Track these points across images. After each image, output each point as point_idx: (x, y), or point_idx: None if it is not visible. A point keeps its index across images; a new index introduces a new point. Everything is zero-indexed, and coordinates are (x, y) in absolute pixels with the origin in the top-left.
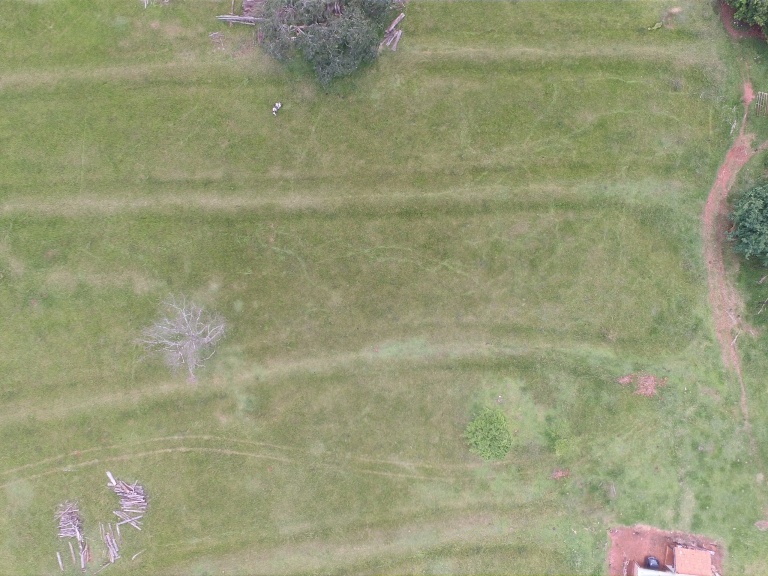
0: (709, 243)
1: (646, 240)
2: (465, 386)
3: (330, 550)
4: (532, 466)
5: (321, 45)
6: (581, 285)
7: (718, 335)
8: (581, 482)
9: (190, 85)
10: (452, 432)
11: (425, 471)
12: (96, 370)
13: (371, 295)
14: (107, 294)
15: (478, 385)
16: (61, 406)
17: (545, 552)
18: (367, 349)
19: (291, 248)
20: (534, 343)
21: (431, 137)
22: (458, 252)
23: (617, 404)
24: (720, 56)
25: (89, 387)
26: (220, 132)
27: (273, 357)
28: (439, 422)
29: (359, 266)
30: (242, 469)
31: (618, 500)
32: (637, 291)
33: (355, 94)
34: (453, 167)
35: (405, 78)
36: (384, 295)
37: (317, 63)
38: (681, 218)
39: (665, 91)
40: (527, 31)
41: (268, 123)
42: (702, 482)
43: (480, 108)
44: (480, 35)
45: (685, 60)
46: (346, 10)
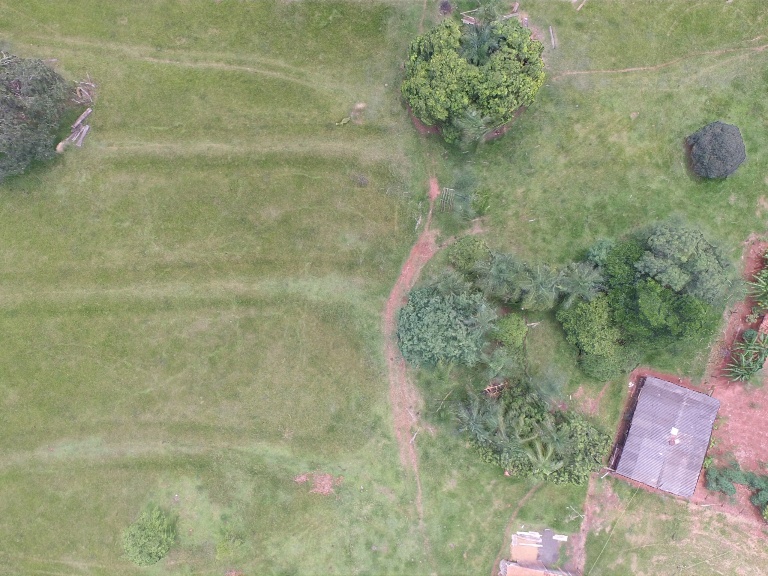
0: (390, 340)
1: (327, 337)
2: (141, 485)
3: None
4: (206, 566)
5: None
6: (260, 383)
7: (397, 433)
8: None
9: None
10: None
11: (98, 571)
12: None
13: (49, 393)
14: None
15: (154, 484)
16: None
17: None
18: (43, 448)
19: None
20: (211, 441)
21: (115, 233)
22: (138, 349)
23: (292, 503)
24: (406, 152)
25: None
26: None
27: None
28: (113, 521)
29: (38, 363)
30: None
31: None
32: (315, 389)
33: (40, 189)
34: (135, 263)
35: (91, 173)
36: (62, 393)
37: None
38: (363, 315)
39: (351, 187)
40: (215, 126)
41: None
42: None
43: (164, 204)
44: (168, 130)
45: (370, 156)
46: None
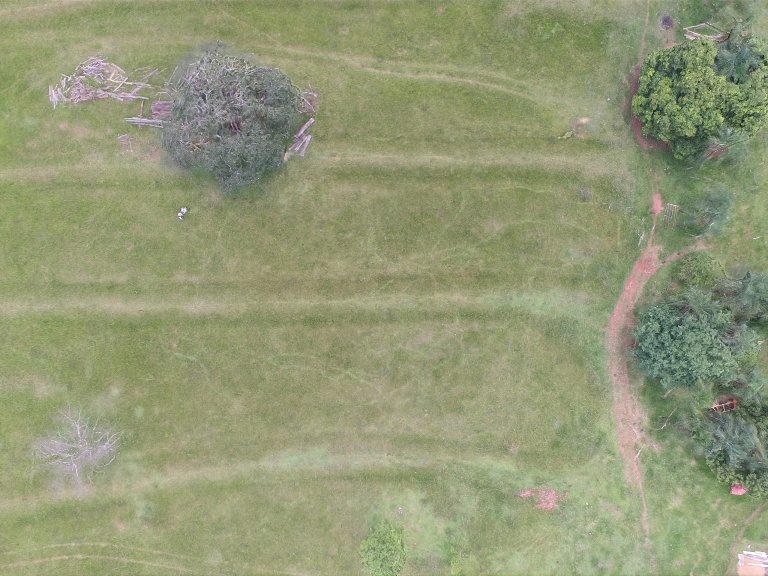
0: (614, 356)
1: (551, 352)
2: (365, 497)
3: None
4: None
5: (218, 161)
6: (484, 396)
7: (621, 449)
8: None
9: (97, 187)
10: (351, 544)
11: None
12: None
13: (273, 403)
14: (7, 398)
15: (378, 496)
16: None
17: None
18: (267, 458)
19: (194, 354)
20: (435, 455)
21: (338, 244)
22: (362, 361)
23: (517, 518)
24: (629, 167)
25: None
26: (126, 235)
27: (173, 464)
28: (338, 533)
29: (262, 373)
30: None
31: None
32: (540, 404)
33: (263, 199)
34: (359, 275)
35: (313, 183)
36: (286, 403)
37: (218, 175)
38: (587, 330)
39: (574, 201)
40: (437, 138)
41: (174, 227)
42: None
43: (387, 215)
44: (390, 141)
45: (594, 170)
46: (244, 127)
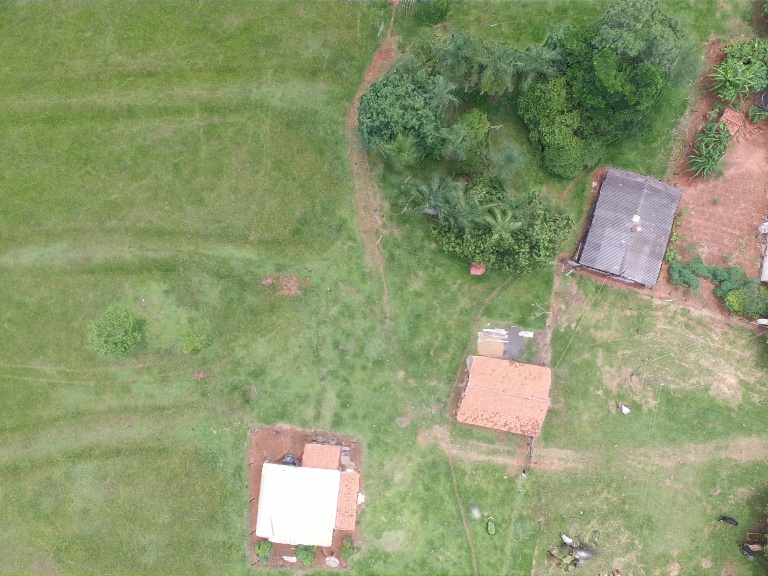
0: (355, 144)
1: (292, 142)
2: (107, 290)
3: None
4: (173, 368)
5: None
6: (225, 188)
7: (363, 235)
8: (222, 383)
9: None
10: None
11: (66, 375)
12: None
13: (13, 201)
14: None
15: (121, 289)
16: None
17: (186, 453)
18: (8, 255)
19: None
20: (176, 246)
21: (77, 43)
22: (102, 157)
23: (259, 305)
24: None
25: None
26: None
27: None
28: (80, 326)
29: (2, 172)
30: None
31: (259, 400)
32: (280, 193)
33: (1, 1)
34: (98, 73)
35: None
36: (27, 201)
37: None
38: (327, 120)
39: None
40: None
41: None
42: (343, 380)
43: (126, 14)
44: None
45: None
46: None
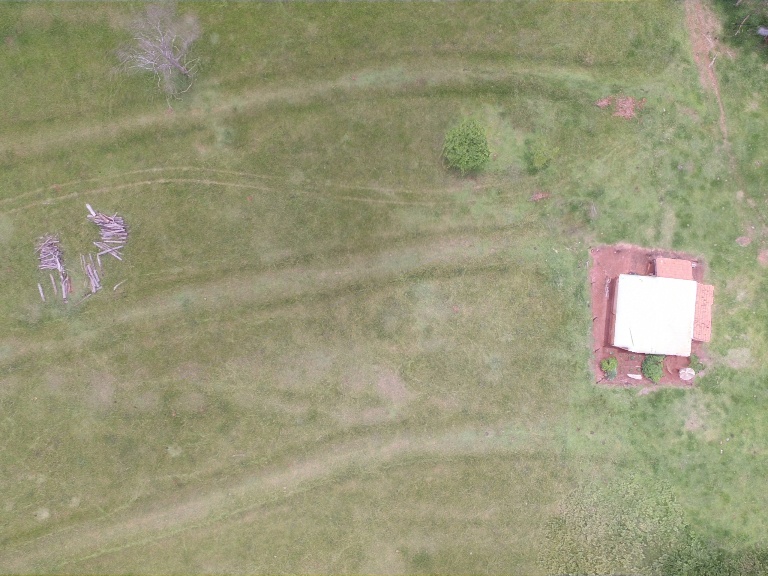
0: None
1: None
2: (443, 112)
3: (311, 275)
4: (512, 189)
5: None
6: (557, 11)
7: (696, 58)
8: (561, 203)
9: None
10: (431, 158)
11: (405, 196)
12: (73, 105)
13: (347, 25)
14: (82, 29)
15: (456, 111)
16: (39, 140)
17: (527, 273)
18: (344, 78)
19: None
20: (511, 68)
21: None
22: None
23: (596, 126)
24: None
25: (67, 122)
26: None
27: (250, 88)
28: (418, 148)
29: None
30: (222, 198)
31: (599, 220)
32: (614, 15)
33: None
34: None
35: None
36: (360, 25)
37: None
38: None
39: None
40: None
41: None
42: (682, 200)
43: None
44: None
45: None
46: None
